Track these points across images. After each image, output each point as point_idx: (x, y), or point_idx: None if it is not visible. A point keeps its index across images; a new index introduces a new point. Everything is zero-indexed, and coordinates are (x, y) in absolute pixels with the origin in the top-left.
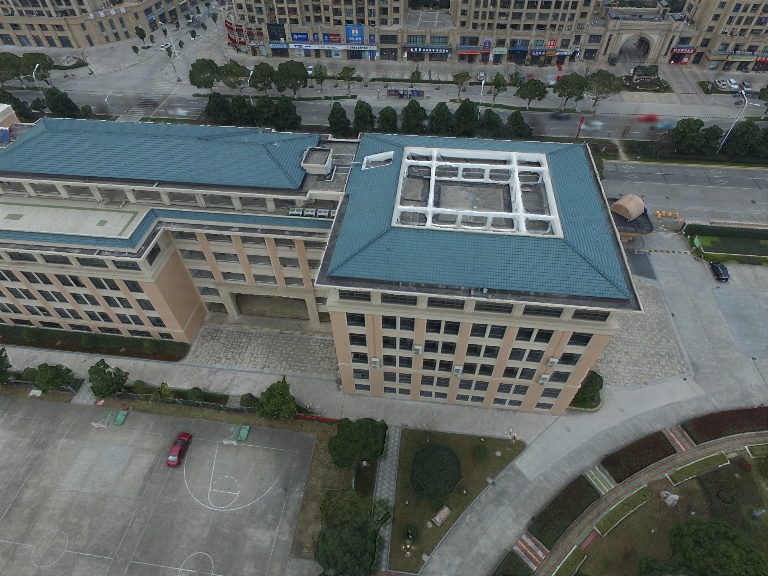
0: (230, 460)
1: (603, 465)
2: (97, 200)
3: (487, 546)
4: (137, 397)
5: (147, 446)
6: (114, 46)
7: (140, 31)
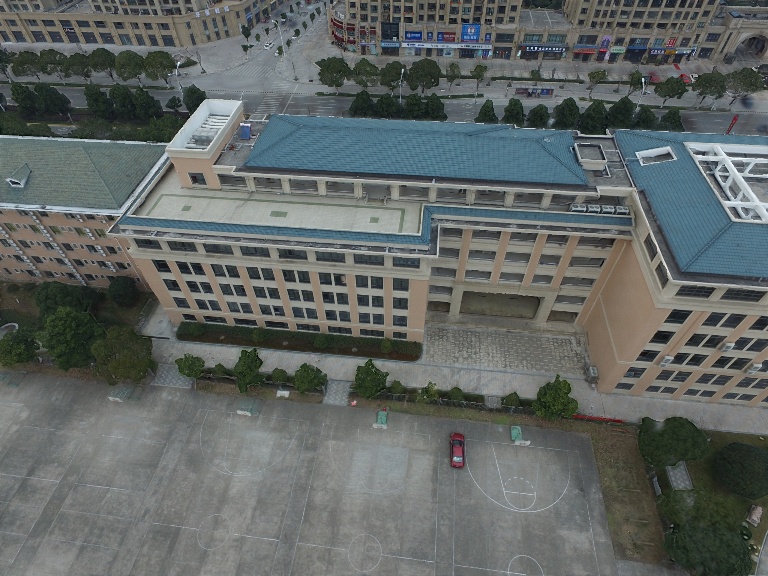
0: (512, 461)
1: None
2: (355, 197)
3: None
4: (395, 397)
5: (421, 447)
6: (216, 45)
7: (246, 30)
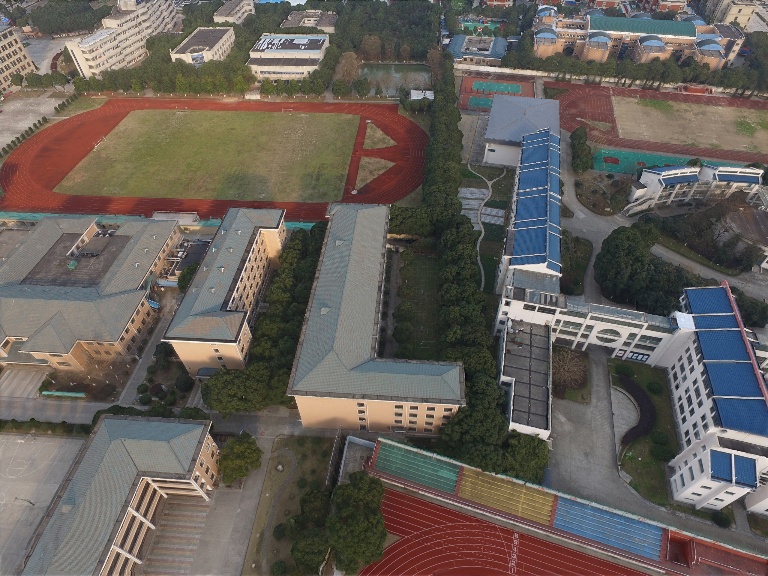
0: None
1: (52, 69)
2: None
3: None
4: None
5: None
6: None
7: None
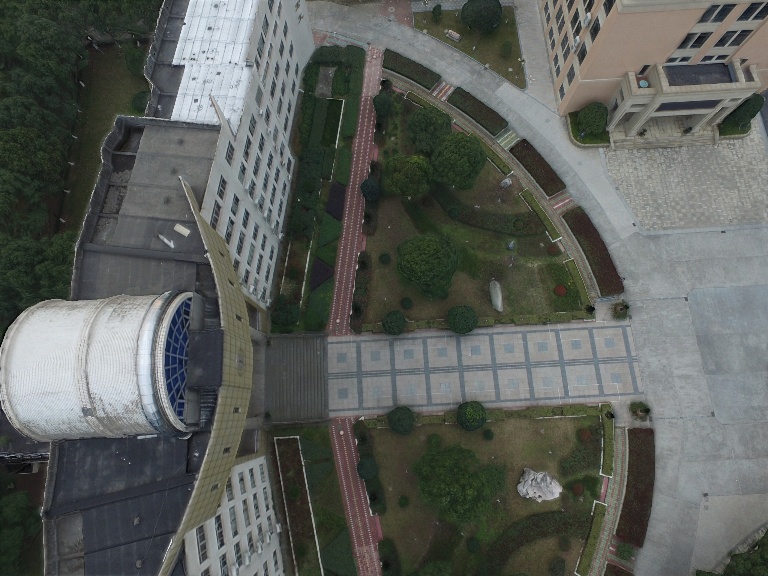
0: None
1: None
2: None
3: (441, 66)
4: None
5: None
6: None
7: None
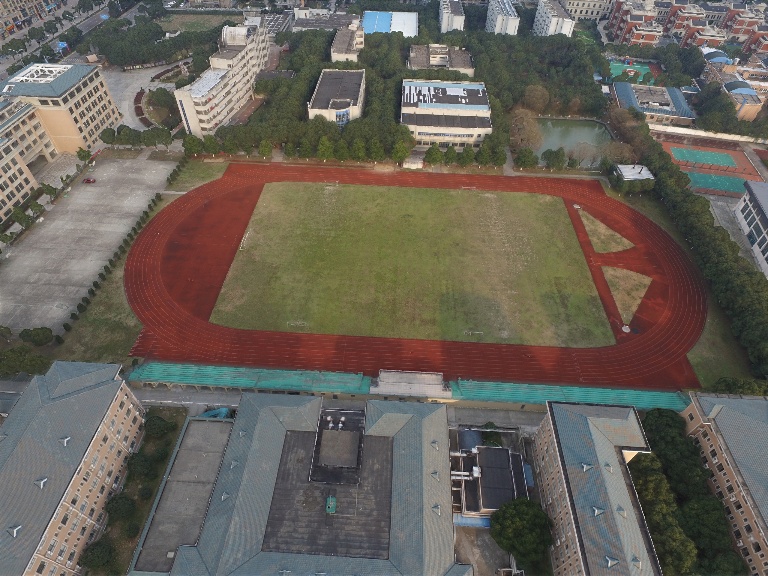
0: (100, 172)
1: (138, 116)
2: None
3: None
4: None
5: None
6: None
7: None
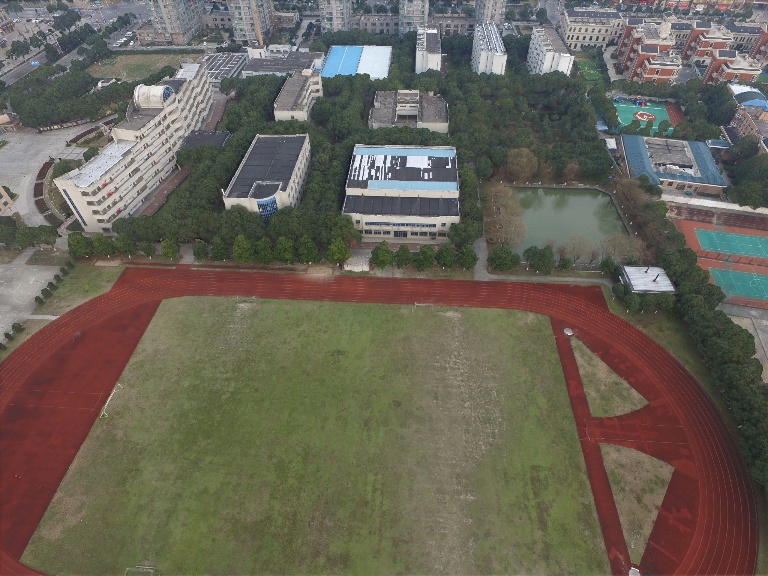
0: None
1: (36, 197)
2: None
3: (40, 222)
4: None
5: None
6: None
7: None
